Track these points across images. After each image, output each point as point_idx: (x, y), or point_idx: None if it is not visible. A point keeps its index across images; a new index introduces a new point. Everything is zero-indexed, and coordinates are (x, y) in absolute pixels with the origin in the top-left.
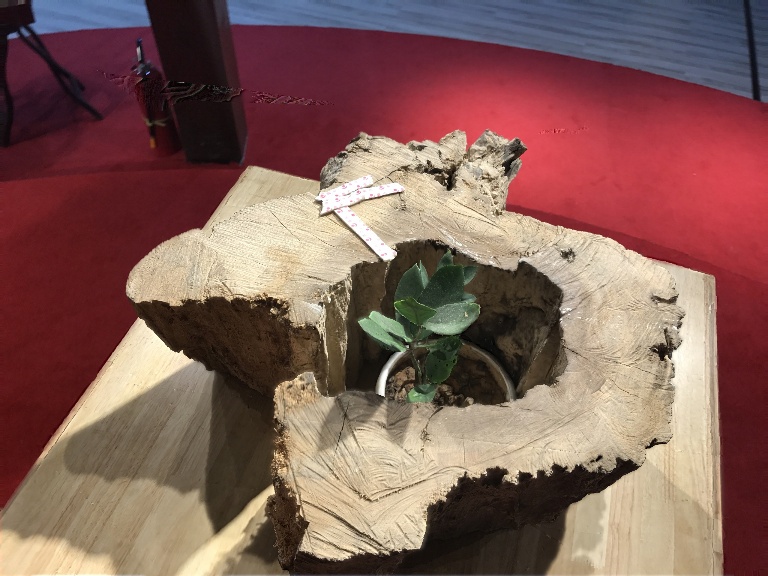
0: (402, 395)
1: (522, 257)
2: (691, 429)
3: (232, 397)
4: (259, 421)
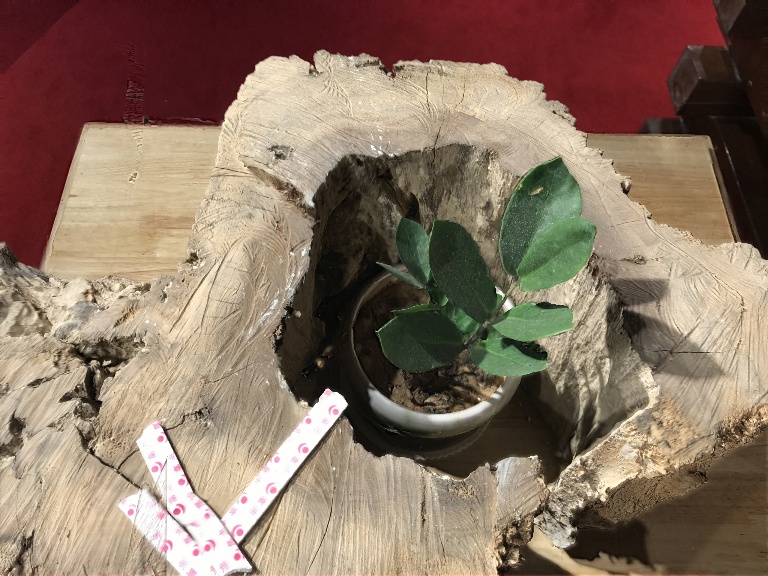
0: (438, 400)
1: (305, 202)
2: None
3: None
4: None
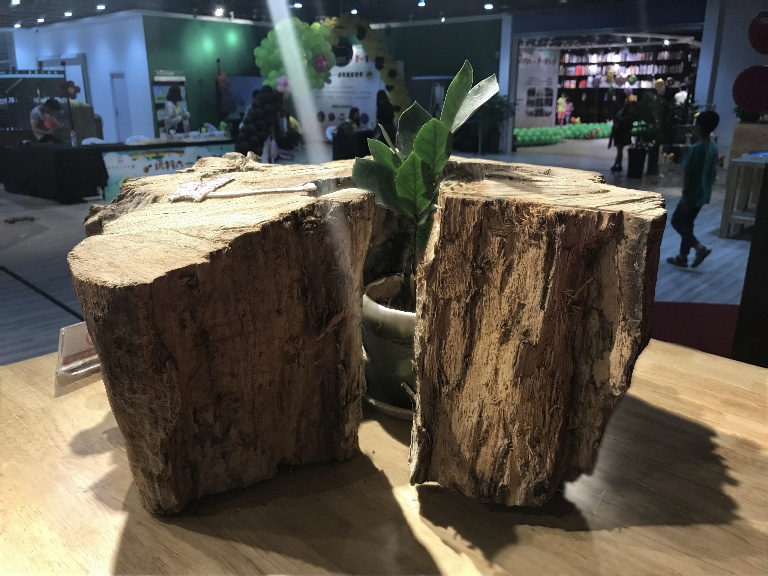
0: None
1: None
2: None
3: (232, 515)
4: (296, 500)
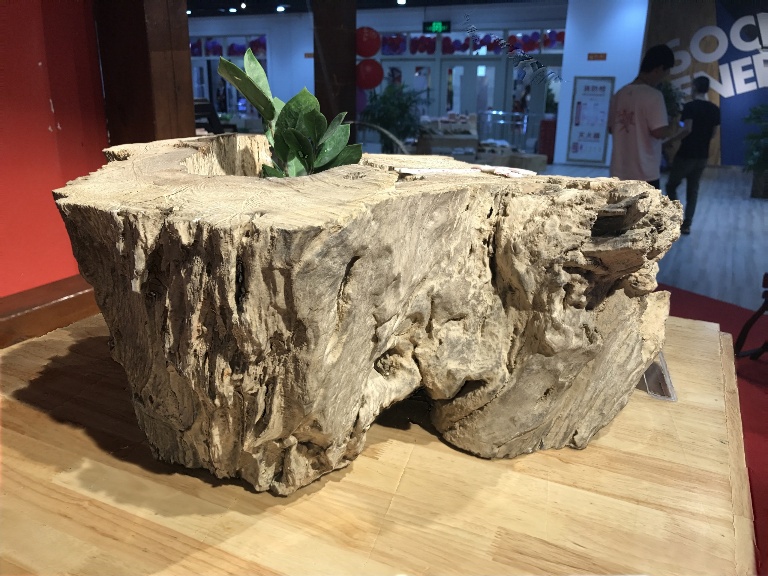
0: None
1: None
2: None
3: None
4: None
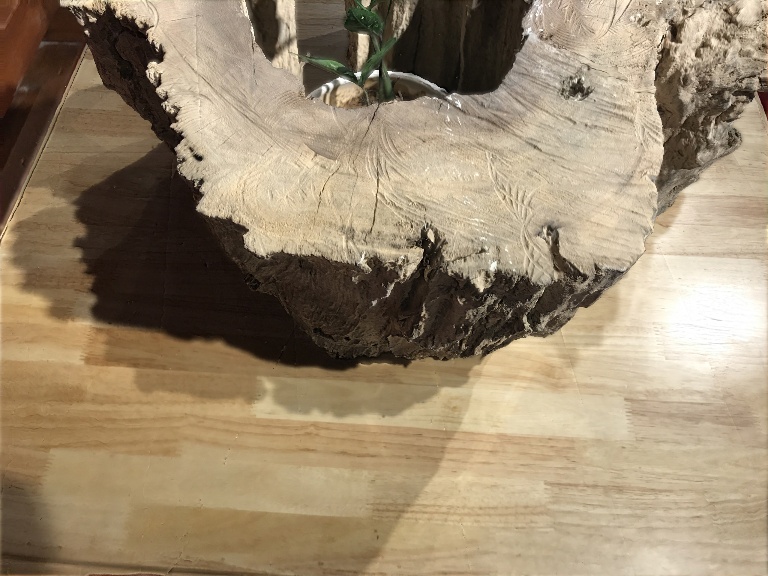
0: None
1: None
2: (512, 555)
3: None
4: None
